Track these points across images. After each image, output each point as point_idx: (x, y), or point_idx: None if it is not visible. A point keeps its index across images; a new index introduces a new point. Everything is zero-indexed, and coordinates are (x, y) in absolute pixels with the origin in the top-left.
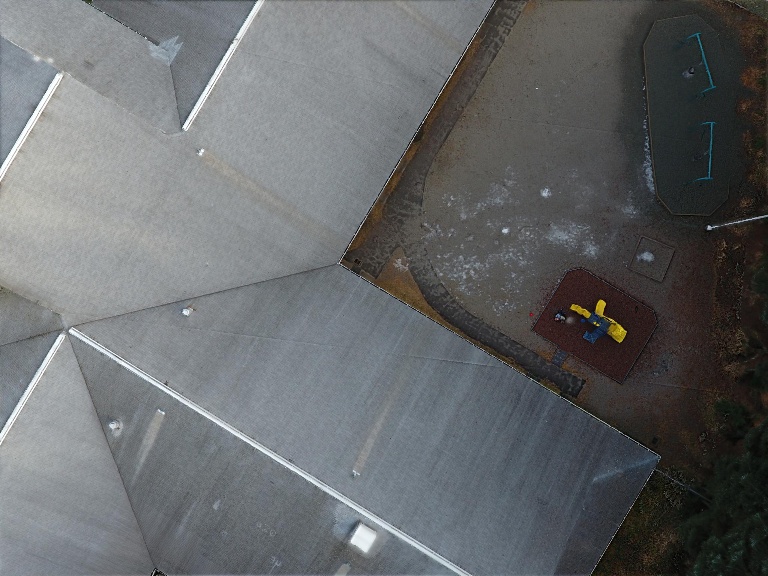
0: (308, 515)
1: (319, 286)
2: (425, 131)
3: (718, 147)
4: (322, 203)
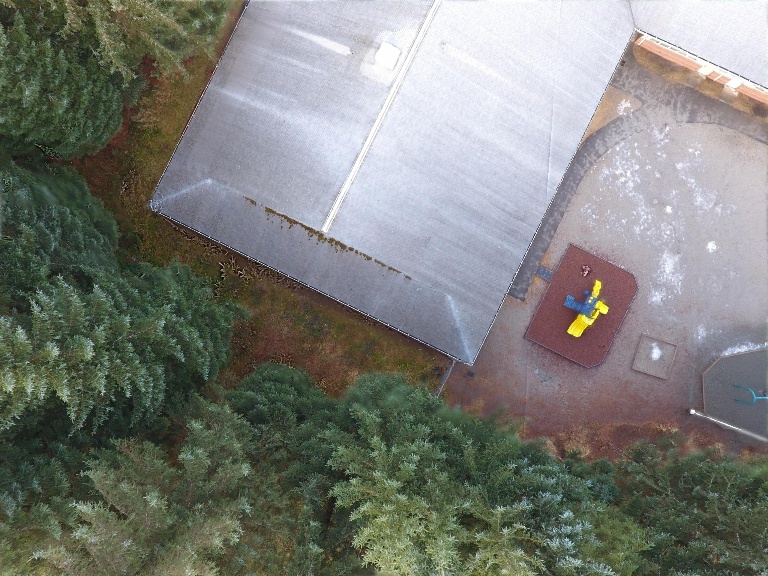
0: (398, 5)
1: (614, 8)
2: (765, 118)
3: None
4: (702, 0)
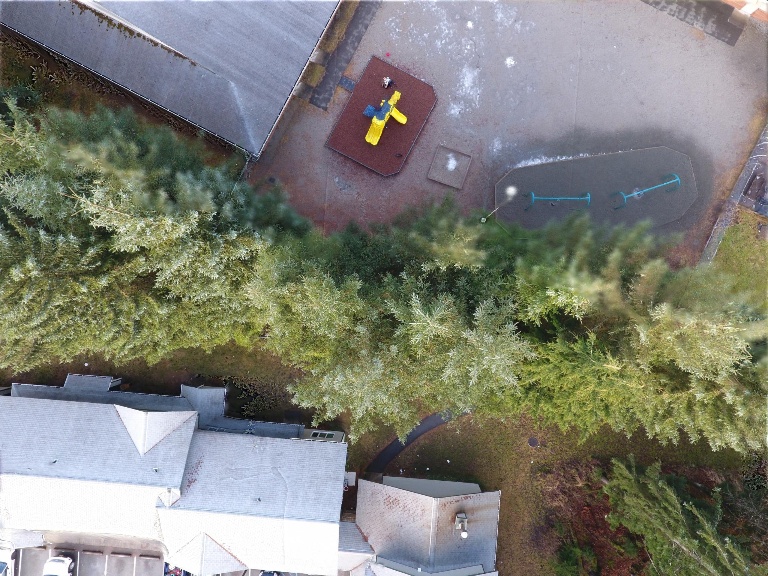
0: None
1: None
2: None
3: (565, 226)
4: None
